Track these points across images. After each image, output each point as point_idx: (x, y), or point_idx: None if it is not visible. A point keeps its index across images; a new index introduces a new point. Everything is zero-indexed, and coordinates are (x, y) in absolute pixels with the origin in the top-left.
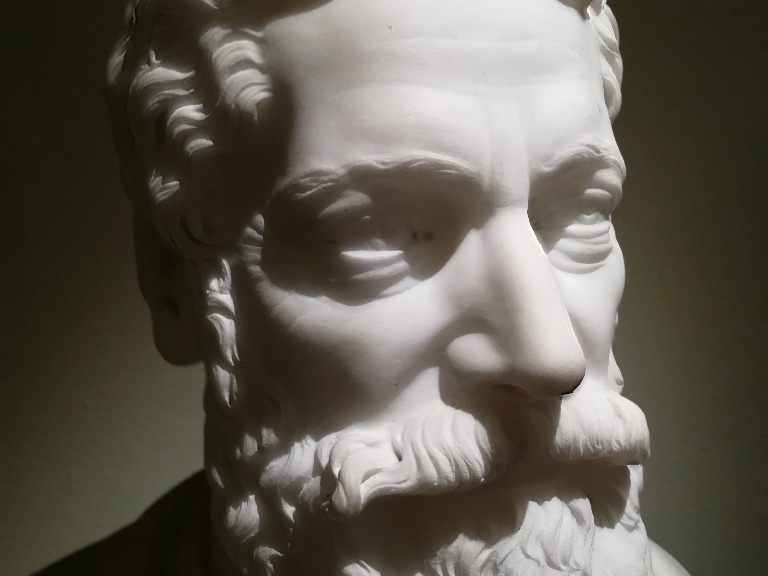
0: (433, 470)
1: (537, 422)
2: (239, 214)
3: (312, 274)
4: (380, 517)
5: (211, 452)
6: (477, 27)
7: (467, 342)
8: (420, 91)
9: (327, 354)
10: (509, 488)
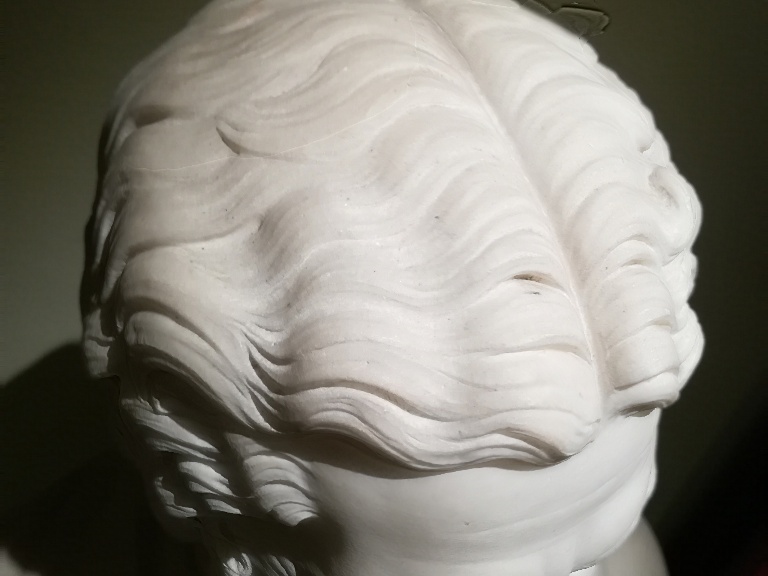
0: None
1: None
2: (264, 543)
3: None
4: None
5: None
6: None
7: None
8: (487, 567)
9: None
10: None
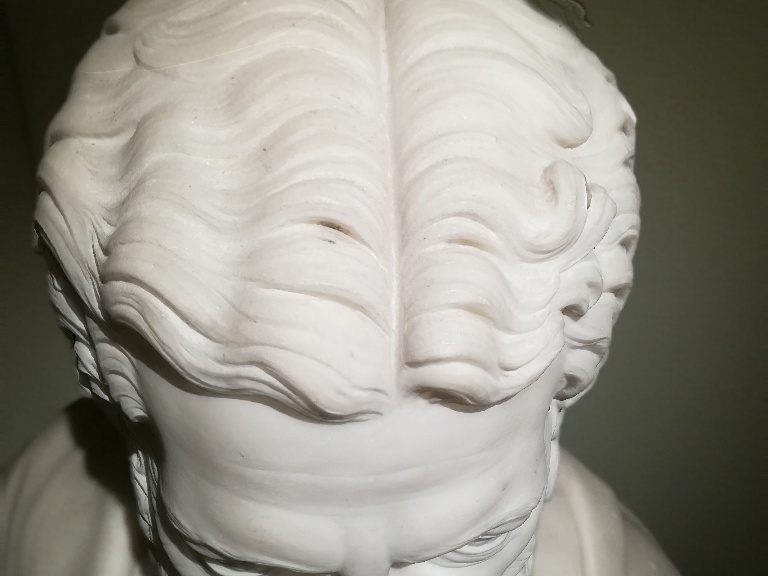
0: None
1: None
2: None
3: None
4: None
5: None
6: (343, 465)
7: None
8: (271, 511)
9: None
10: None
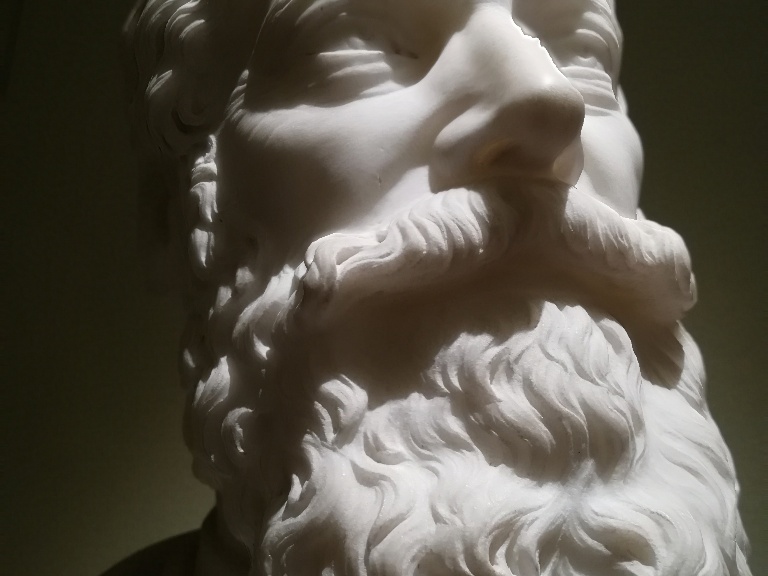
0: (421, 237)
1: (542, 195)
2: (227, 83)
3: (291, 91)
4: (366, 330)
5: (185, 338)
6: None
7: (455, 122)
8: None
9: (305, 158)
10: (520, 288)
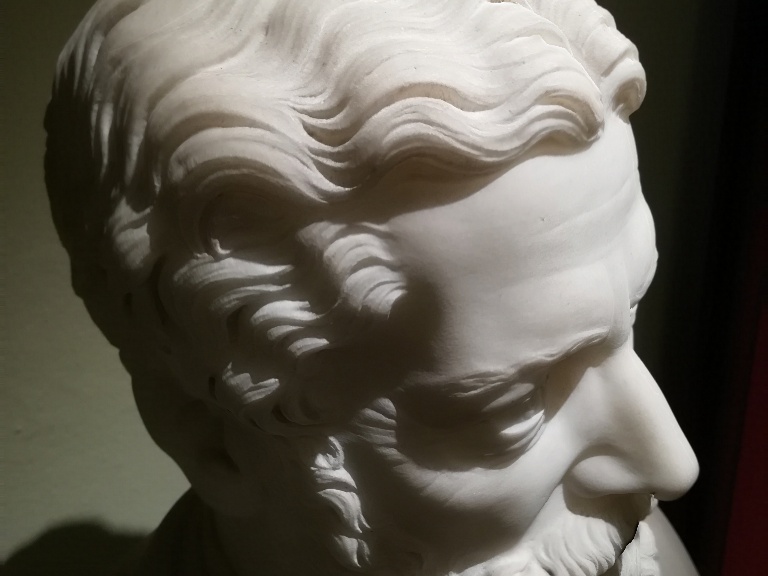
0: None
1: (640, 502)
2: (352, 396)
3: (462, 451)
4: None
5: None
6: (600, 191)
7: (595, 465)
8: (570, 275)
9: (482, 514)
10: None
